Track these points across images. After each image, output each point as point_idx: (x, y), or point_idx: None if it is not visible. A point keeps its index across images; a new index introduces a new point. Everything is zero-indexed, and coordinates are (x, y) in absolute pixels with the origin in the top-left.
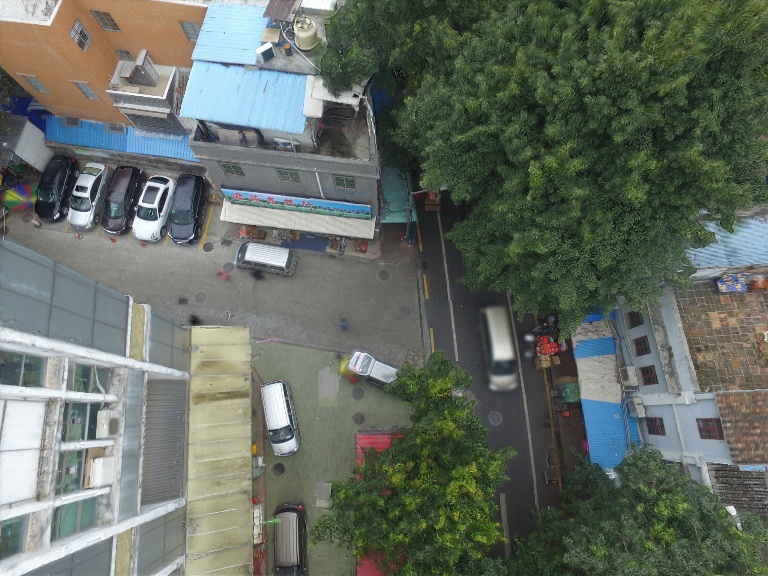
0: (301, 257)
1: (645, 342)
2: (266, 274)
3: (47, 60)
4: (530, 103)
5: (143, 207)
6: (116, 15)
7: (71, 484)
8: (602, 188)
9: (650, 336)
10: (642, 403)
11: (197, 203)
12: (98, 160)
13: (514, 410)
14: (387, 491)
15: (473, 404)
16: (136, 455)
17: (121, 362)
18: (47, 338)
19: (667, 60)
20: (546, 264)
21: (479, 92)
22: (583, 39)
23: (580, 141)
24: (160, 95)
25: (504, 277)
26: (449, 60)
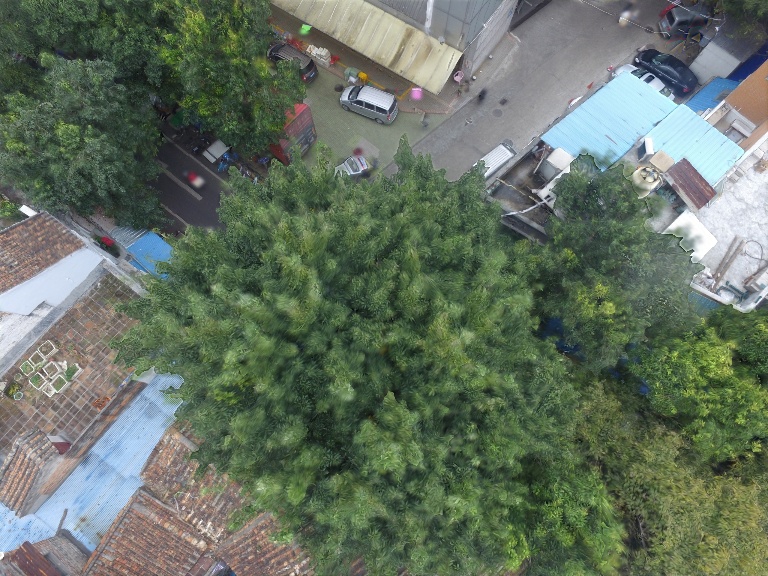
0: None
1: None
2: None
3: None
4: None
5: None
6: None
7: None
8: None
9: None
10: None
11: None
12: None
13: None
14: (238, 4)
15: (239, 99)
16: None
17: None
18: None
19: None
20: None
21: None
22: None
23: None
24: None
25: None
26: None
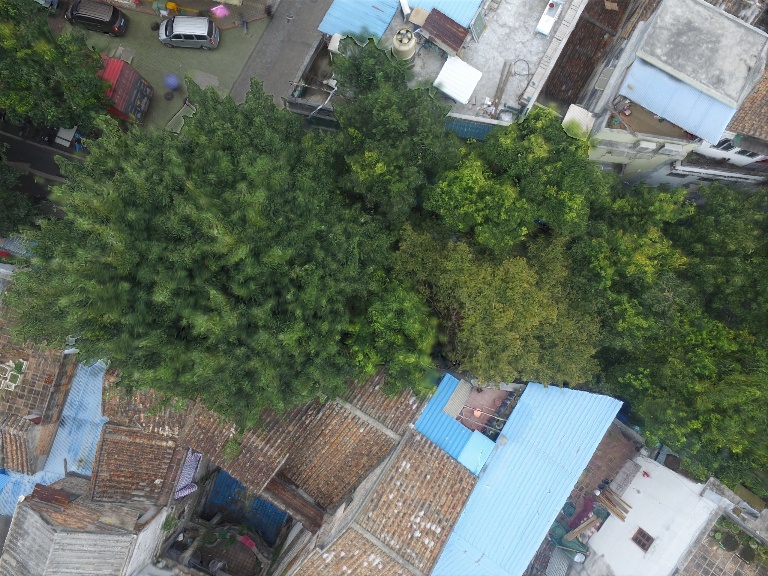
0: None
1: None
2: None
3: None
4: None
5: None
6: None
7: None
8: None
9: None
10: None
11: None
12: None
13: None
14: None
15: (41, 87)
16: None
17: None
18: None
19: None
20: None
21: None
22: None
23: None
24: None
25: None
26: None
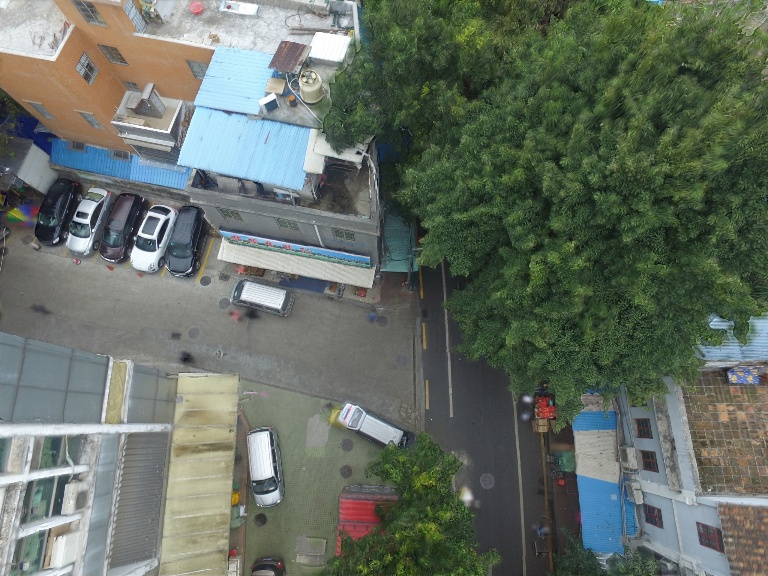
0: (299, 297)
1: (647, 425)
2: (262, 313)
3: (52, 91)
4: (537, 187)
5: (142, 237)
6: (123, 50)
7: (30, 566)
8: (608, 280)
9: (653, 421)
10: (640, 488)
11: (197, 236)
12: (102, 184)
13: (507, 474)
14: None
15: None
16: (105, 524)
17: (94, 431)
18: (10, 424)
19: (684, 168)
20: (544, 355)
21: (483, 171)
22: (595, 132)
23: (587, 231)
24: (165, 128)
25: (501, 354)
26: (456, 127)
